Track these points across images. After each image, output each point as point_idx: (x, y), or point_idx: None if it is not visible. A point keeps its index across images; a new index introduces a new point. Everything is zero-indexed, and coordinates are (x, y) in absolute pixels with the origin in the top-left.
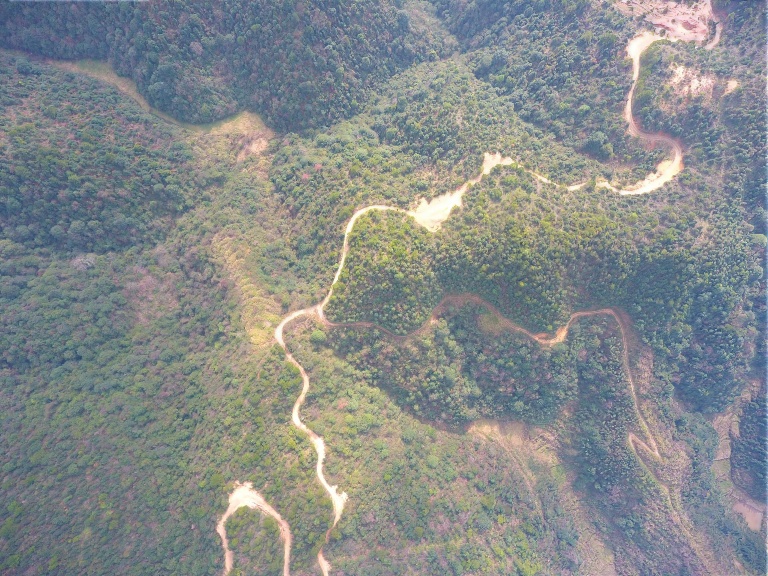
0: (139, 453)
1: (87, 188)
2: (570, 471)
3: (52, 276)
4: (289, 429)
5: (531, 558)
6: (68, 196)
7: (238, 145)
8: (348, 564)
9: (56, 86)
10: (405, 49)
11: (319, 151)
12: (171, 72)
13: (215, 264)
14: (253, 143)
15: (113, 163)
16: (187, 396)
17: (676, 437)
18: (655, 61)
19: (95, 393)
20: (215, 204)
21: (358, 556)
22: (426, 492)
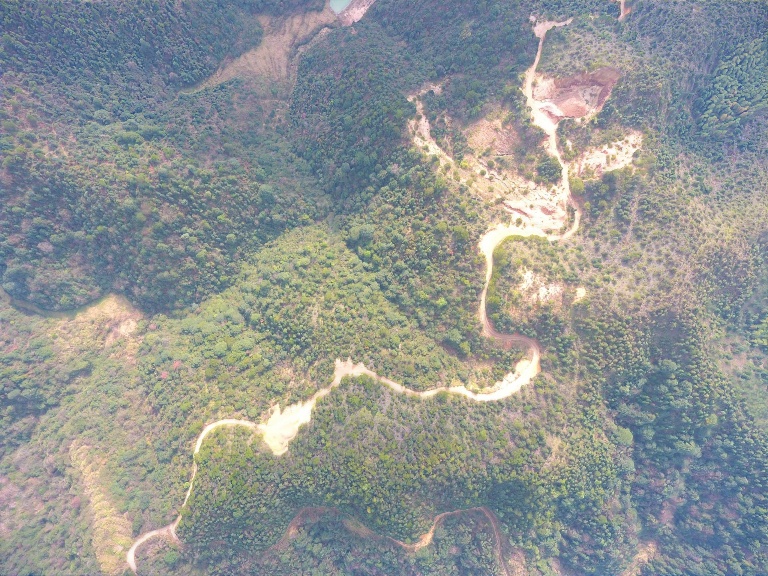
0: None
1: None
2: None
3: None
4: None
5: None
6: None
7: (105, 330)
8: None
9: None
10: (273, 220)
11: (183, 340)
12: (21, 273)
13: (71, 475)
14: (121, 325)
15: None
16: None
17: None
18: (504, 264)
19: None
20: (77, 401)
21: None
22: None
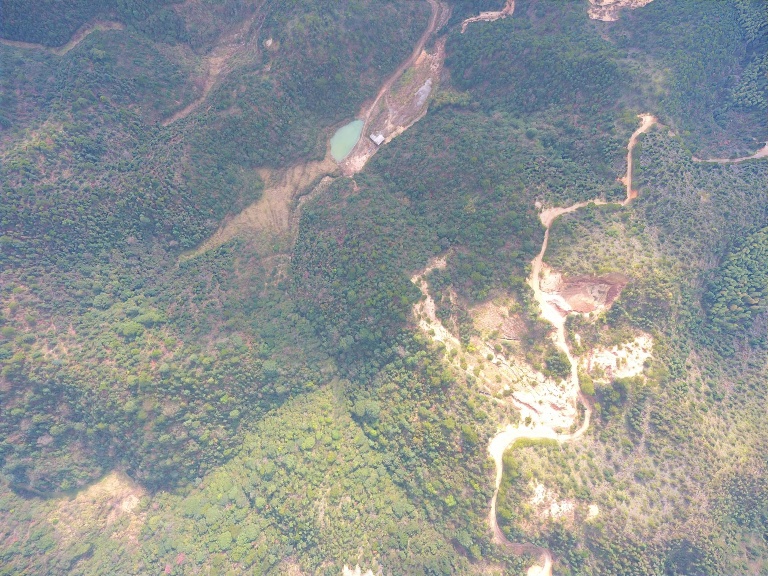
0: None
1: None
2: None
3: None
4: None
5: None
6: None
7: (106, 508)
8: None
9: None
10: (277, 393)
11: (186, 524)
12: (20, 467)
13: None
14: (123, 501)
15: None
16: None
17: None
18: (514, 476)
19: None
20: None
21: None
22: None
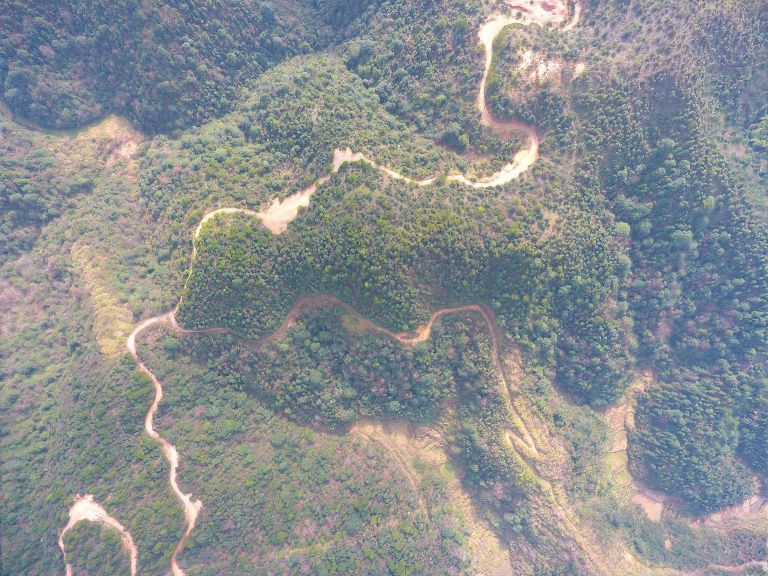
0: None
1: None
2: (459, 468)
3: None
4: (140, 439)
5: (408, 558)
6: None
7: (106, 149)
8: (203, 572)
9: None
10: (273, 43)
11: (183, 153)
12: (23, 78)
13: (72, 273)
14: (122, 147)
15: None
16: (41, 409)
17: (552, 432)
18: (503, 46)
19: None
20: (78, 211)
21: (218, 563)
22: (294, 496)
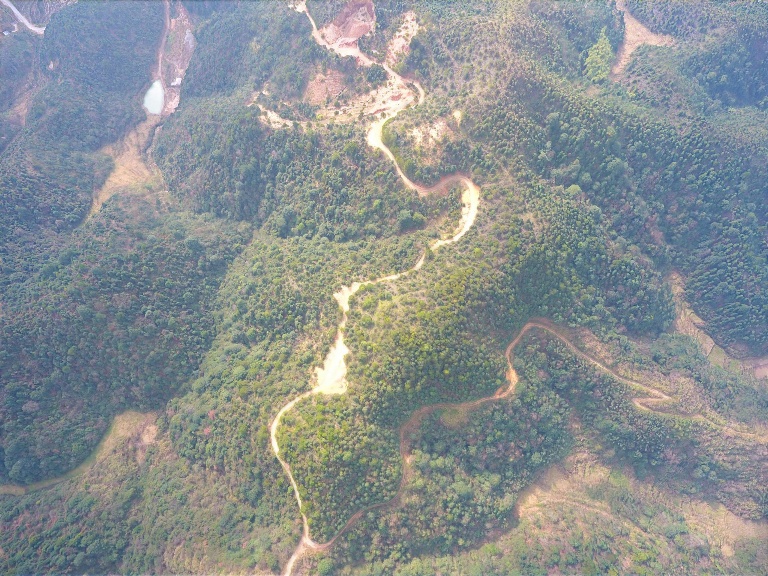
0: None
1: None
2: (624, 468)
3: None
4: None
5: None
6: None
7: (130, 451)
8: None
9: None
10: (212, 262)
11: (203, 398)
12: (21, 446)
13: None
14: (142, 437)
15: None
16: None
17: (665, 372)
18: (394, 139)
19: None
20: (145, 524)
21: None
22: None
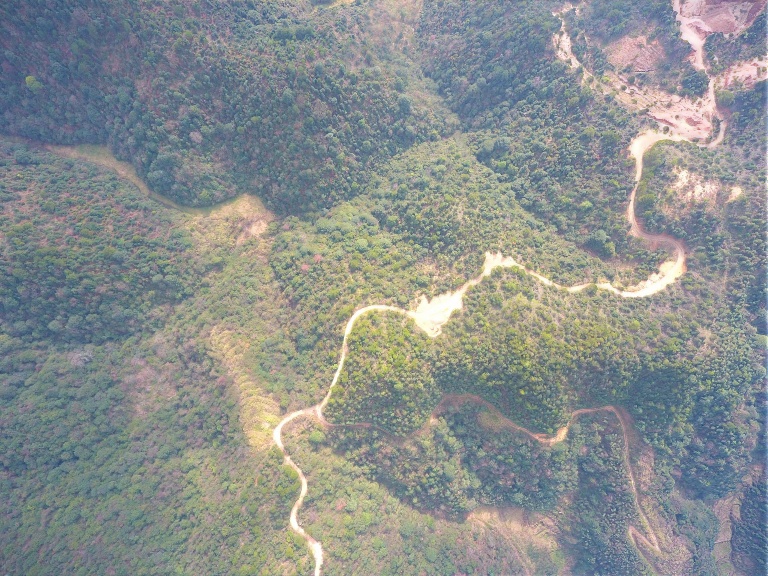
0: (136, 562)
1: (85, 285)
2: (570, 556)
3: (49, 373)
4: (287, 535)
5: None
6: (66, 294)
7: (238, 228)
8: None
9: (55, 177)
10: (406, 131)
11: (319, 238)
12: (170, 161)
13: (214, 358)
14: (253, 225)
15: (111, 258)
16: (184, 498)
17: (677, 532)
18: (658, 164)
19: (92, 497)
20: (214, 292)
21: None
22: None
